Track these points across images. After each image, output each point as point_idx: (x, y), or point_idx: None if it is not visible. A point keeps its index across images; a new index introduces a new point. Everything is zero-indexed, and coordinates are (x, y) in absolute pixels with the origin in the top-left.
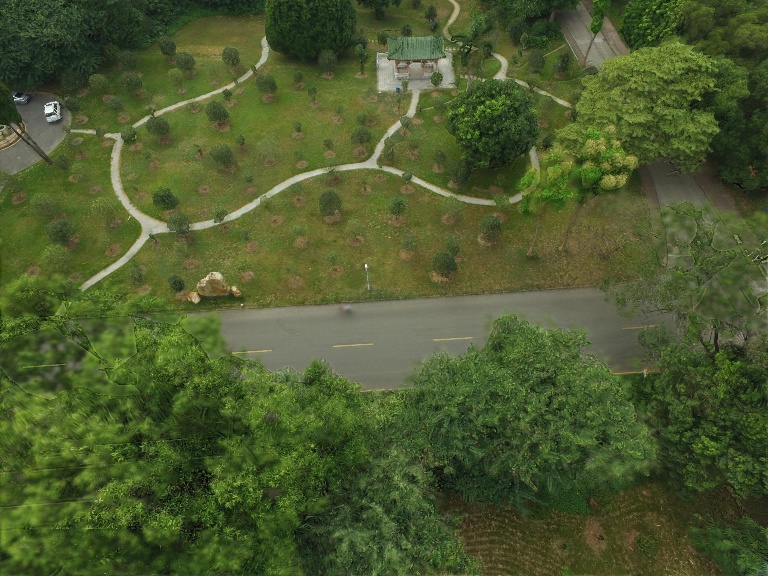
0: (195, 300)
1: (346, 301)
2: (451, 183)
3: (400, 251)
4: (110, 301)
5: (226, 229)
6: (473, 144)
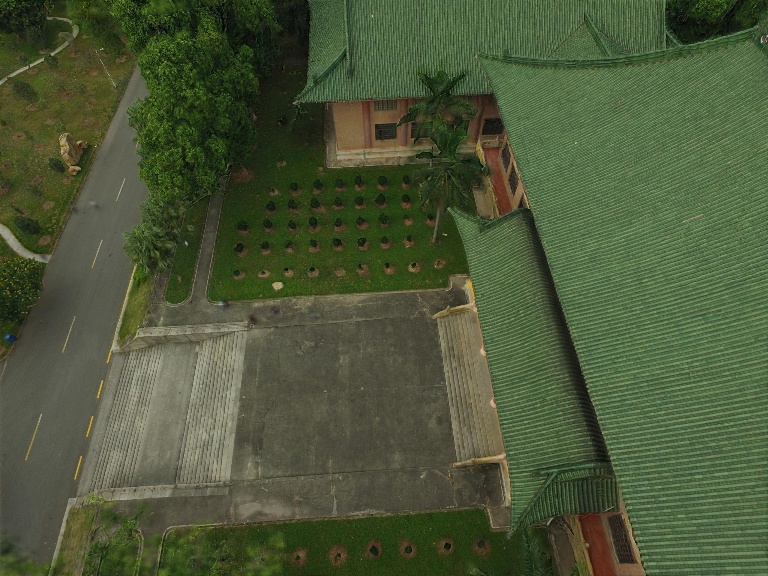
0: (78, 168)
1: (120, 98)
2: (42, 52)
3: (91, 75)
4: (48, 225)
5: (8, 165)
6: (21, 7)
